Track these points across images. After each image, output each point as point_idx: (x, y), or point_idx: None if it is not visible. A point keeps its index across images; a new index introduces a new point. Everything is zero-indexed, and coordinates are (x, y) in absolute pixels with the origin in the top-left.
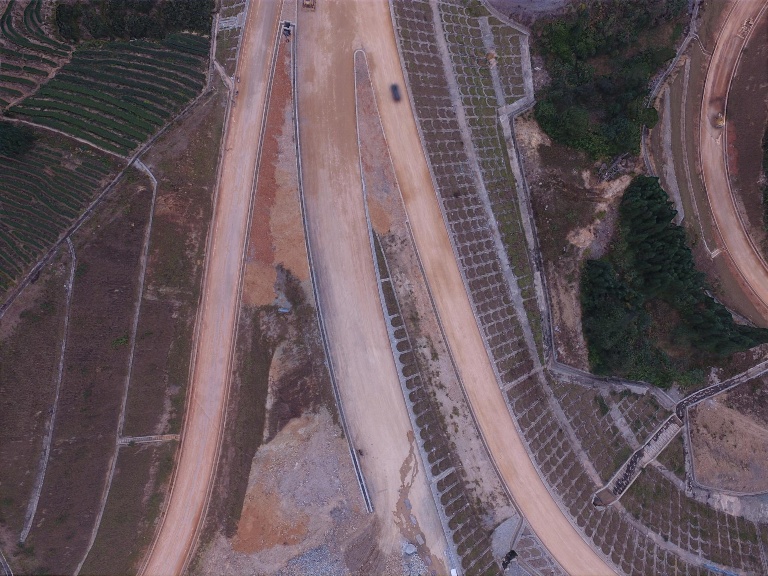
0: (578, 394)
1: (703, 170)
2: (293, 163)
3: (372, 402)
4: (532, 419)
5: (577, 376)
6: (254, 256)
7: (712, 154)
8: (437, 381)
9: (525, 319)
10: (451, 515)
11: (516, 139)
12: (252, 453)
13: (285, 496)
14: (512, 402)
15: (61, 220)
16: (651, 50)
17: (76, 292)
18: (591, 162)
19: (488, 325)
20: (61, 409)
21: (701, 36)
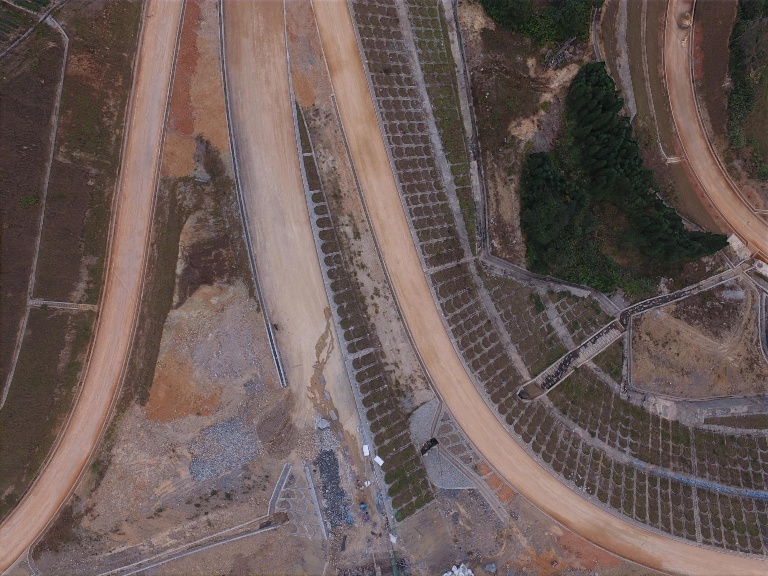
0: (512, 289)
1: (666, 73)
2: (216, 31)
3: (289, 277)
4: (457, 306)
5: (512, 271)
6: (174, 126)
7: (677, 57)
8: (358, 261)
9: (457, 207)
10: (366, 393)
11: (459, 22)
12: (163, 320)
13: (198, 367)
14: (436, 286)
15: None
16: None
17: None
18: (537, 48)
19: (414, 206)
20: None
21: None
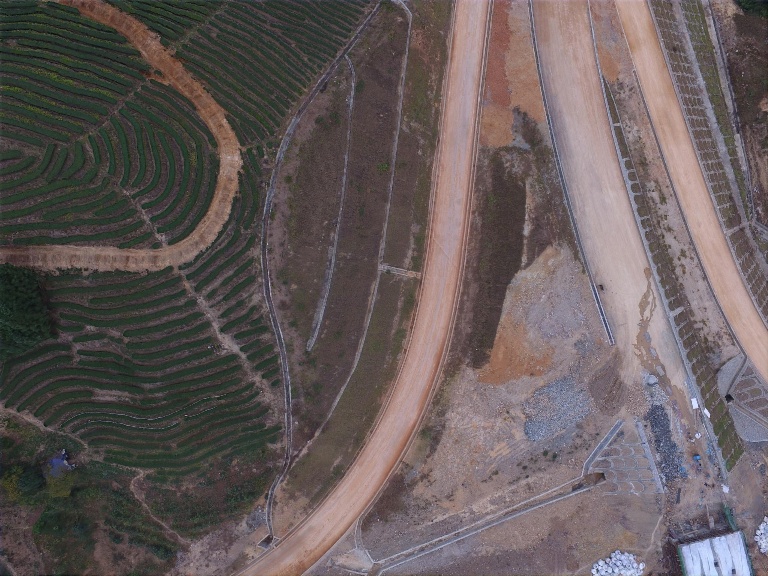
0: None
1: None
2: (525, 10)
3: (610, 240)
4: (748, 266)
5: None
6: (491, 99)
7: None
8: (665, 224)
9: (732, 175)
10: (687, 349)
11: (712, 8)
12: (507, 281)
13: (532, 328)
14: (734, 247)
15: (336, 39)
16: None
17: (356, 108)
18: None
19: (709, 173)
20: (344, 221)
21: None
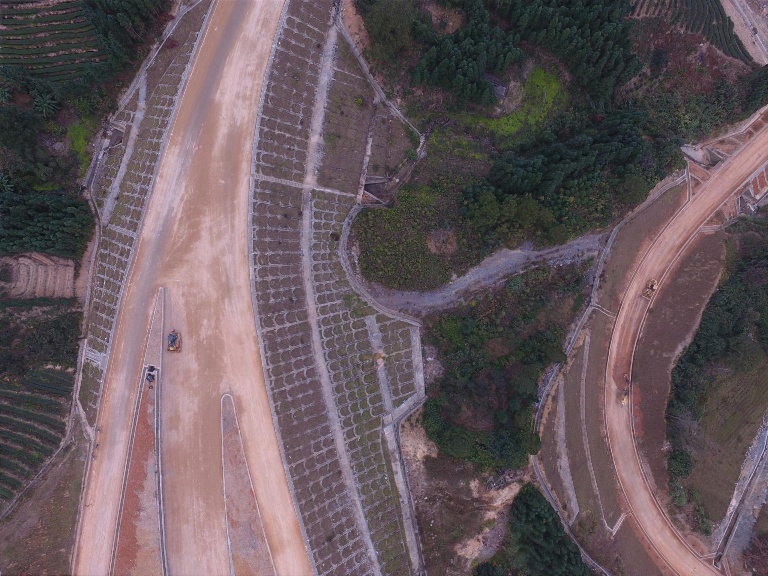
0: None
1: (608, 433)
2: (155, 521)
3: None
4: None
5: None
6: None
7: (618, 415)
8: None
9: None
10: None
11: (402, 450)
12: None
13: None
14: None
15: None
16: (547, 336)
17: None
18: (479, 473)
19: None
20: None
21: (603, 305)
